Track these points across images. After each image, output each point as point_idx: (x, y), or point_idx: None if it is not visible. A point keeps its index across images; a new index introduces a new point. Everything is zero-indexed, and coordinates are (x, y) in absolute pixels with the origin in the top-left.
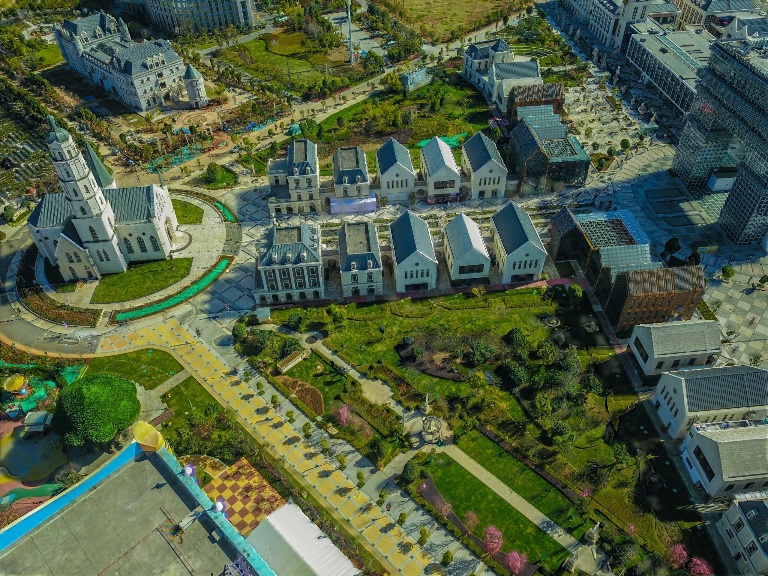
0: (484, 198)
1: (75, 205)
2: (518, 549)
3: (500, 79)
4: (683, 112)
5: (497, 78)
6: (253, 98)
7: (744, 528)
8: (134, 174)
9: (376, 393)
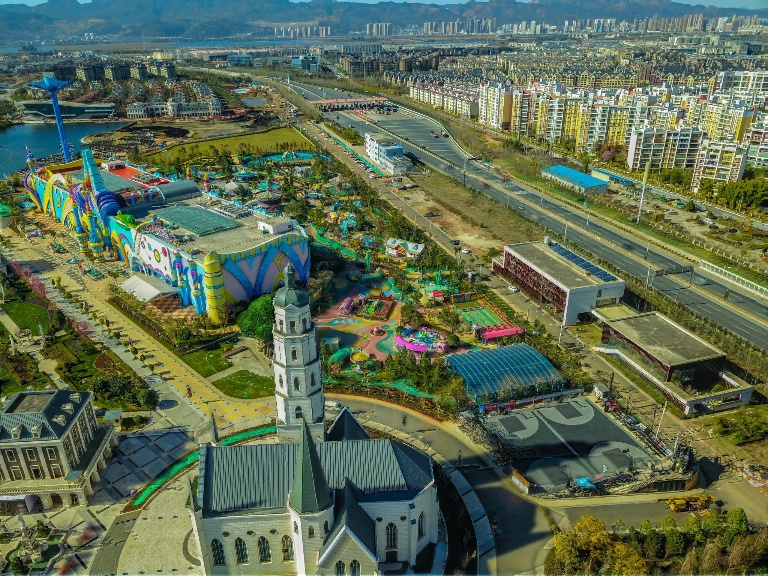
0: None
1: None
2: None
3: None
4: None
5: None
6: None
7: None
8: None
9: (47, 365)
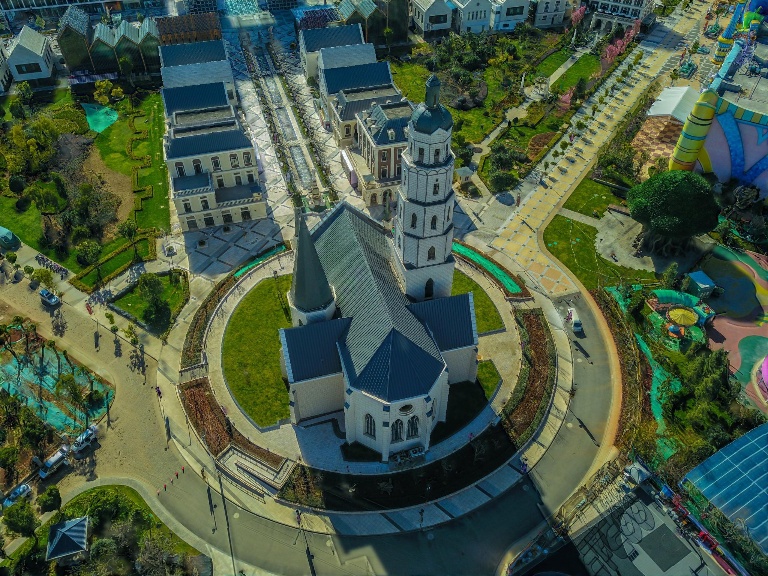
0: None
1: None
2: (596, 65)
3: None
4: (99, 2)
5: None
6: None
7: (550, 3)
8: (106, 440)
9: (517, 114)
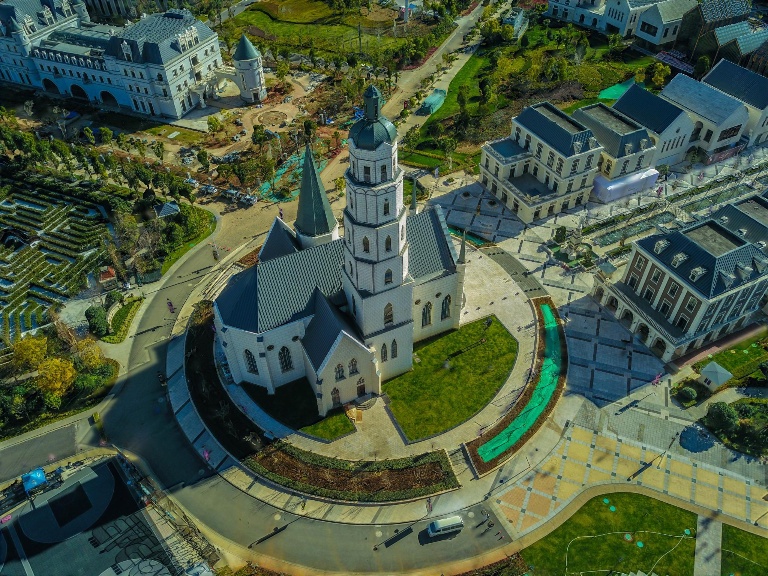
0: (759, 143)
1: (379, 269)
2: None
3: (635, 7)
4: None
5: (631, 6)
6: (323, 78)
7: None
8: (252, 210)
9: None
